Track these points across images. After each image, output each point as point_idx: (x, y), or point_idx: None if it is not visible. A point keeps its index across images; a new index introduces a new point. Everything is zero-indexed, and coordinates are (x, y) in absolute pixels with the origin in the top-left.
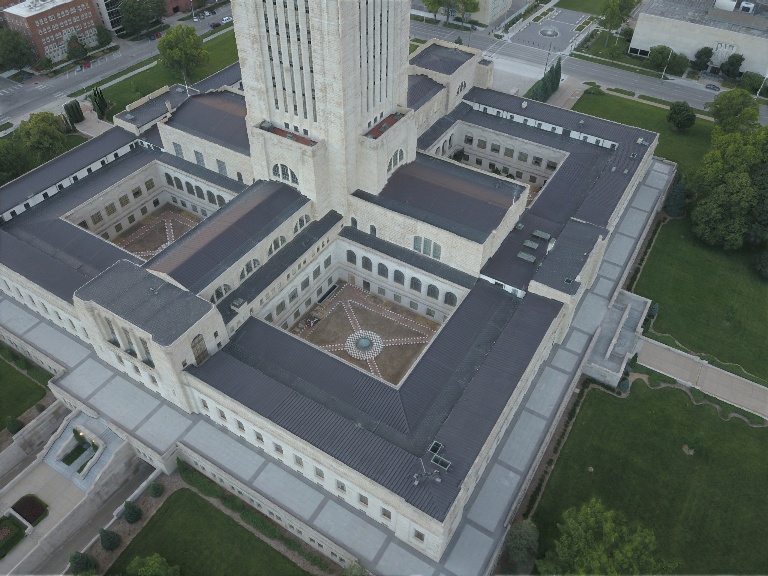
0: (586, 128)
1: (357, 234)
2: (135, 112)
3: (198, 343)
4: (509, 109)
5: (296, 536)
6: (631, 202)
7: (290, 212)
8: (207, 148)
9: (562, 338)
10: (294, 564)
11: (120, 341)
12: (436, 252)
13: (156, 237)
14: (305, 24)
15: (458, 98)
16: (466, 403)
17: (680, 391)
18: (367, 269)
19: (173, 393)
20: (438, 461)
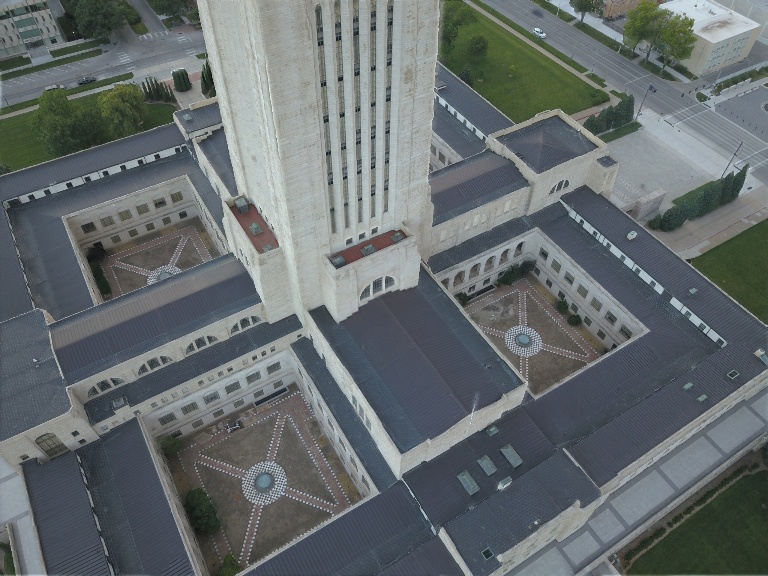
0: (695, 301)
1: (310, 353)
2: (197, 112)
3: (49, 439)
4: (609, 234)
5: None
6: (710, 428)
7: (230, 311)
8: (220, 186)
9: None
10: None
11: None
12: (369, 423)
13: (162, 255)
14: None
15: (552, 197)
16: None
17: None
18: None
19: None
20: None
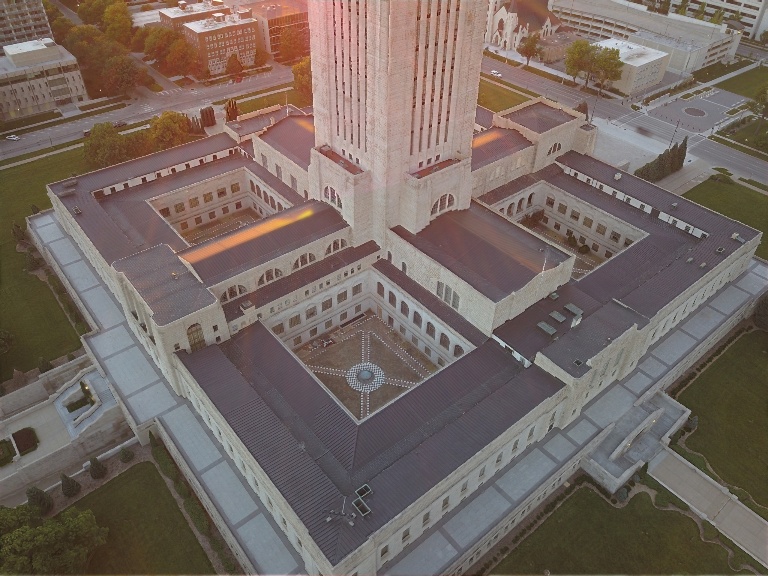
0: (678, 212)
1: (390, 268)
2: (244, 123)
3: (196, 332)
4: (600, 178)
5: (223, 538)
6: (710, 300)
7: (326, 233)
8: (285, 163)
9: (564, 423)
10: (210, 564)
11: (138, 314)
12: (455, 302)
13: None
14: (364, 59)
15: (549, 159)
16: (416, 457)
17: (690, 520)
18: (393, 305)
19: (167, 372)
20: (359, 505)
